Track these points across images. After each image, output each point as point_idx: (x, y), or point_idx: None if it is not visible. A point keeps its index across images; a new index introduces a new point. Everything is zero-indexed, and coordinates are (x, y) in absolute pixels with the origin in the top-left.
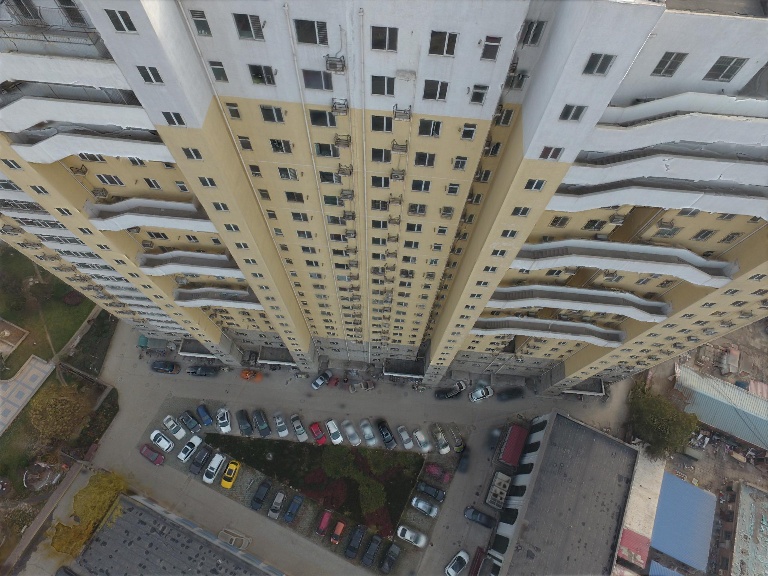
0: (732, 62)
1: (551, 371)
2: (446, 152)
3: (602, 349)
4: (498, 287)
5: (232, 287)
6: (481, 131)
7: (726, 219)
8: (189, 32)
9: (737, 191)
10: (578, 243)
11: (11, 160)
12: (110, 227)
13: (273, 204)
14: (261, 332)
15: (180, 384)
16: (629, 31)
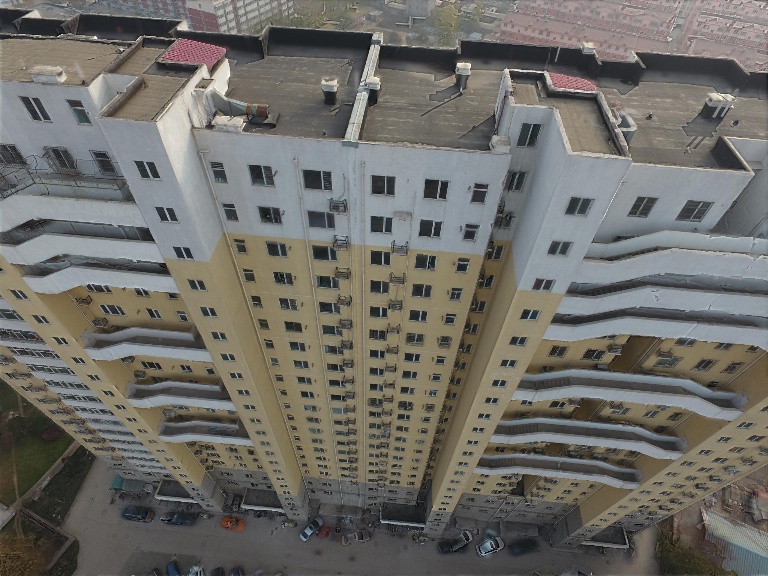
0: (699, 205)
1: (566, 518)
2: (442, 284)
3: (619, 491)
4: (501, 420)
5: (222, 420)
6: (474, 265)
7: (724, 349)
8: (207, 179)
9: (729, 321)
10: (579, 373)
11: (19, 291)
12: (104, 357)
13: (271, 334)
14: (248, 471)
15: (151, 535)
16: (602, 179)
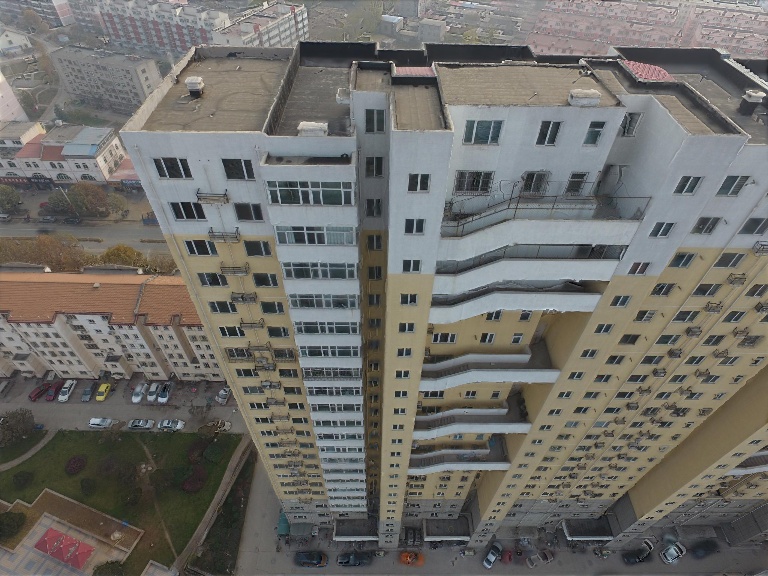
0: None
1: (752, 514)
2: None
3: None
4: None
5: (464, 447)
6: None
7: None
8: None
9: None
10: None
11: (410, 323)
12: (435, 387)
13: None
14: (440, 501)
15: None
16: None
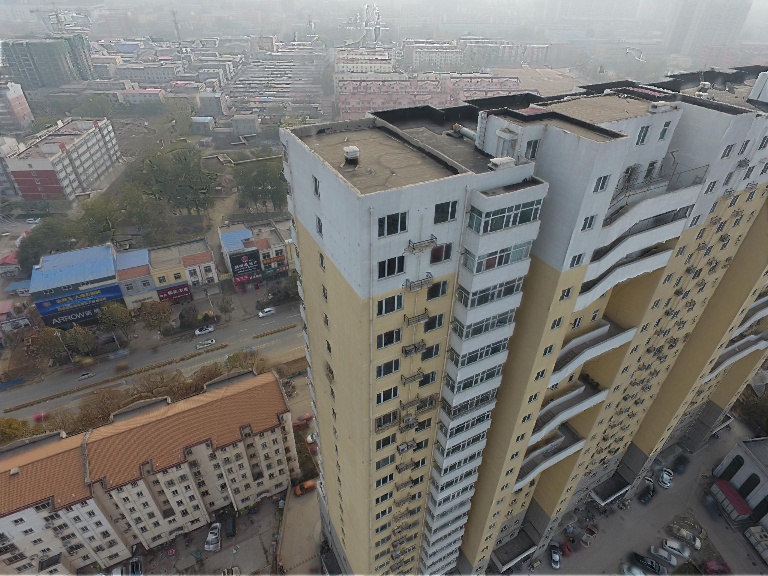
0: None
1: (698, 419)
2: (750, 210)
3: (754, 357)
4: None
5: (541, 445)
6: None
7: None
8: None
9: None
10: None
11: (559, 318)
12: (559, 379)
13: None
14: (507, 521)
15: None
16: None
